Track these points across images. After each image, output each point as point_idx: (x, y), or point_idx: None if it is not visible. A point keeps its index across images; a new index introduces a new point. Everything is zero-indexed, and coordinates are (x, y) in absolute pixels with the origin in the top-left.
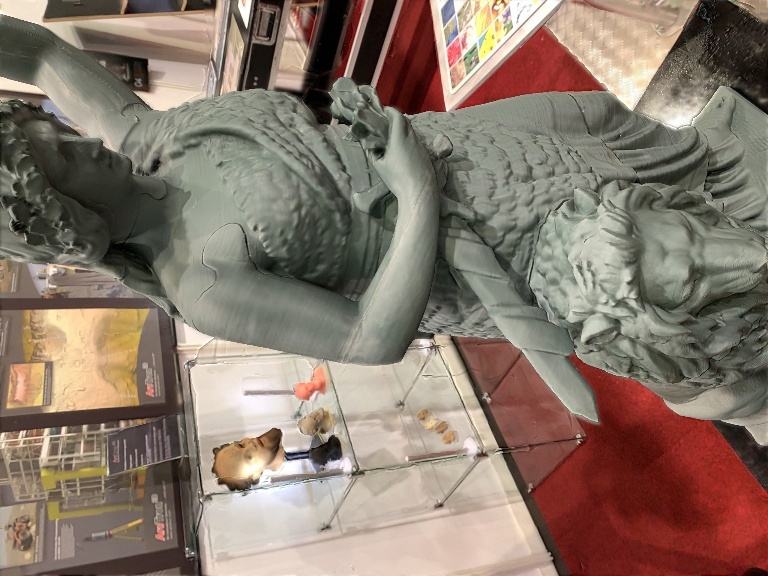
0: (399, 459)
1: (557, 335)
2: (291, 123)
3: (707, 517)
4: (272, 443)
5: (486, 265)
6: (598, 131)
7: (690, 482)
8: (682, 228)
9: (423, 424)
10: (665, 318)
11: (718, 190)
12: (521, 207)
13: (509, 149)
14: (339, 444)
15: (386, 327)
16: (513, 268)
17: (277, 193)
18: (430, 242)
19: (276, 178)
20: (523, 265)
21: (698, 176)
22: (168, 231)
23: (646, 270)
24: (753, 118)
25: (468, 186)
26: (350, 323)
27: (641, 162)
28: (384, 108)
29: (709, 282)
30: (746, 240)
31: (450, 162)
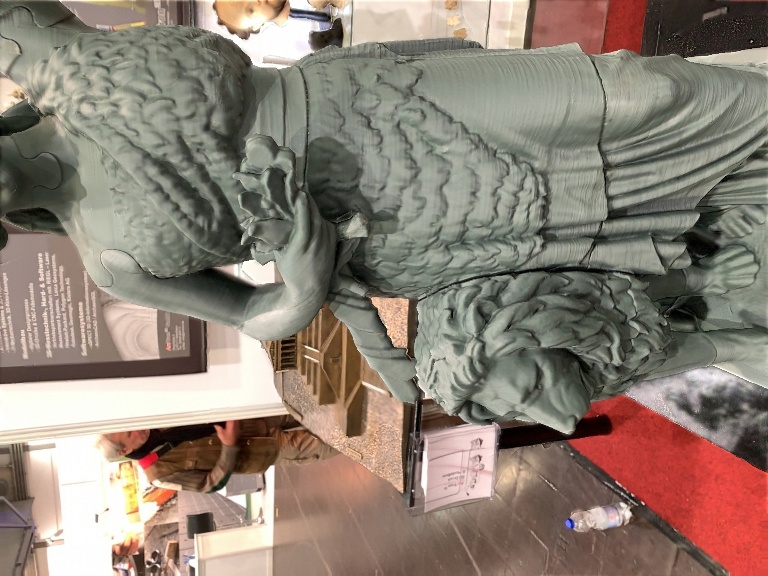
0: (415, 27)
1: (405, 368)
2: (199, 147)
3: None
4: (277, 2)
5: (362, 323)
6: (615, 138)
7: None
8: (520, 394)
9: (447, 15)
10: (475, 416)
11: None
12: (427, 275)
13: (454, 203)
14: (342, 36)
15: None
16: None
17: (166, 254)
18: (307, 320)
19: (166, 240)
20: None
21: None
22: (69, 208)
23: (476, 398)
24: None
25: (380, 250)
26: (234, 321)
27: (637, 185)
28: (296, 201)
29: None
30: (566, 416)
31: (373, 220)
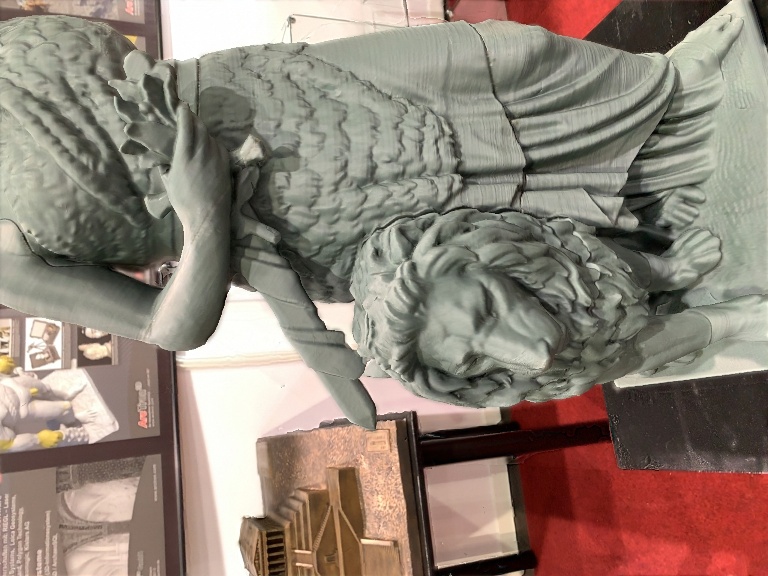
0: None
1: (347, 360)
2: (84, 90)
3: None
4: None
5: (282, 289)
6: (508, 88)
7: None
8: (470, 316)
9: None
10: (435, 386)
11: (665, 146)
12: (344, 221)
13: (356, 138)
14: None
15: (171, 336)
16: (333, 273)
17: (48, 201)
18: (212, 273)
19: (47, 182)
20: (345, 271)
21: (638, 135)
22: None
23: (424, 345)
24: (749, 60)
25: (286, 192)
26: (141, 321)
27: (548, 135)
28: (177, 107)
29: (492, 361)
30: (534, 340)
31: (272, 157)
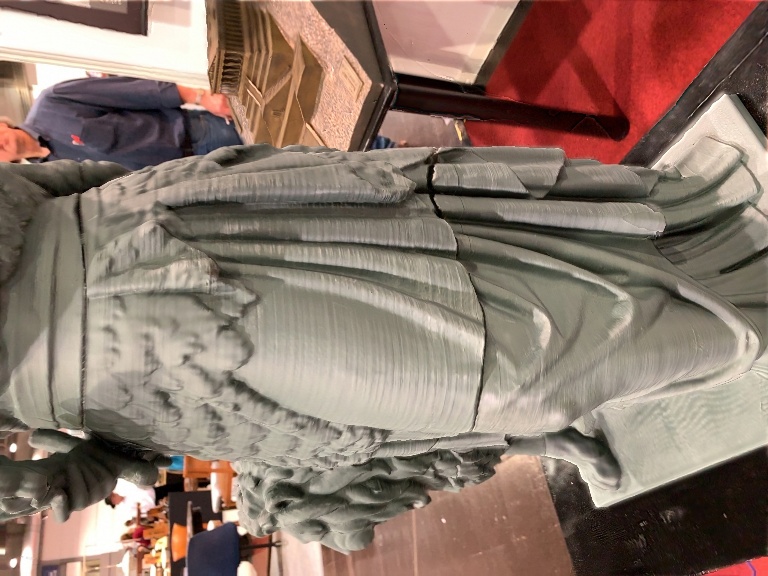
0: None
1: None
2: None
3: (665, 65)
4: None
5: None
6: None
7: (700, 32)
8: None
9: None
10: None
11: None
12: None
13: None
14: None
15: None
16: None
17: None
18: None
19: None
20: None
21: None
22: None
23: None
24: None
25: None
26: None
27: None
28: None
29: None
30: None
31: None
